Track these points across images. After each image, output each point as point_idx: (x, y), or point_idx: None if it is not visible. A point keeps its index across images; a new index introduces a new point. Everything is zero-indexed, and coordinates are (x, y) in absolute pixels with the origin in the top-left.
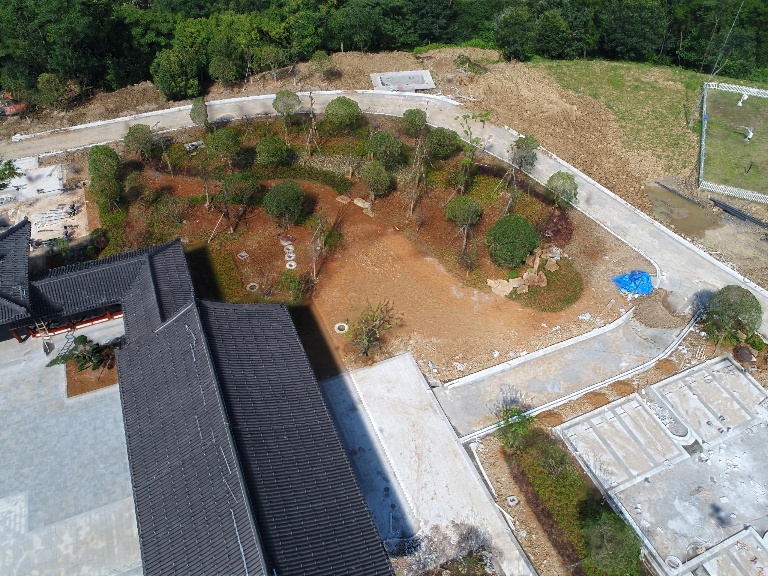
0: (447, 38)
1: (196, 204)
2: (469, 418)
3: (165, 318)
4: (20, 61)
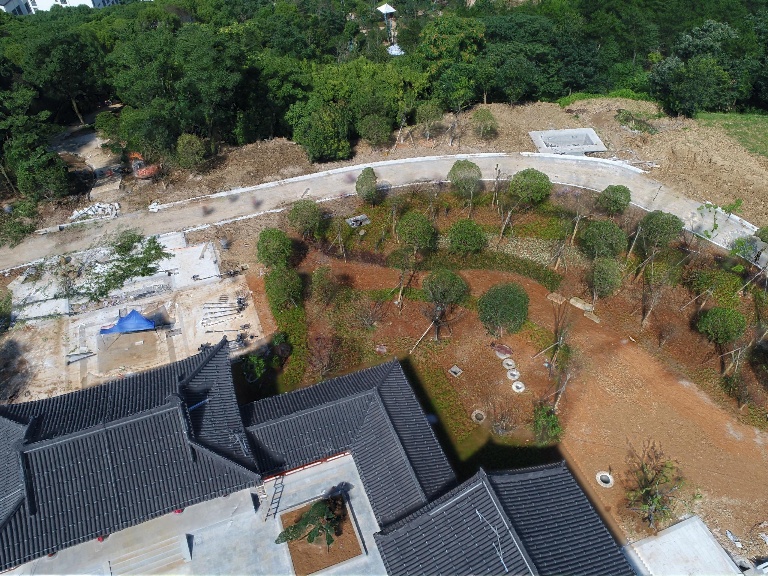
0: (592, 87)
1: (384, 301)
2: None
3: (421, 483)
4: (159, 121)
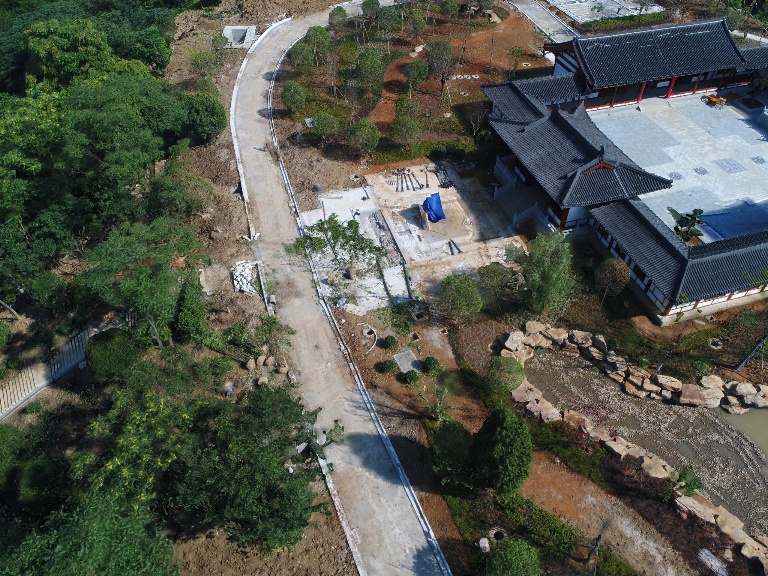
0: None
1: None
2: None
3: None
4: None
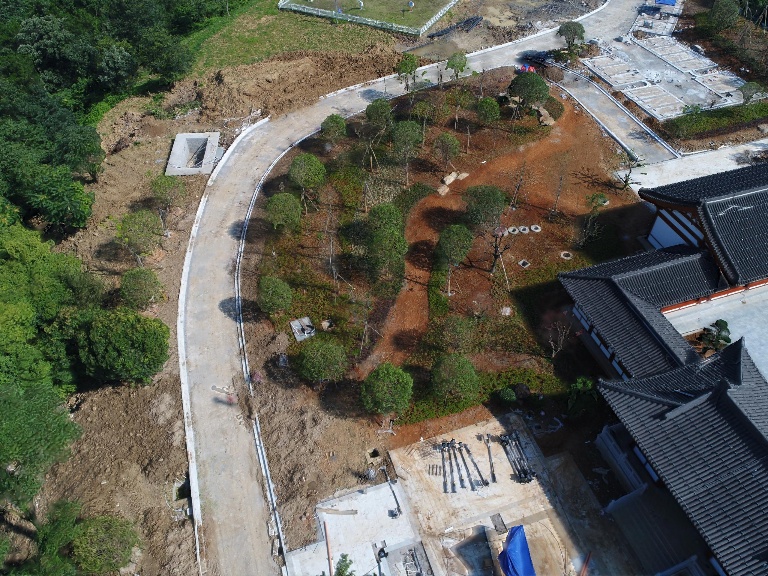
0: None
1: (448, 303)
2: (660, 153)
3: None
4: None
